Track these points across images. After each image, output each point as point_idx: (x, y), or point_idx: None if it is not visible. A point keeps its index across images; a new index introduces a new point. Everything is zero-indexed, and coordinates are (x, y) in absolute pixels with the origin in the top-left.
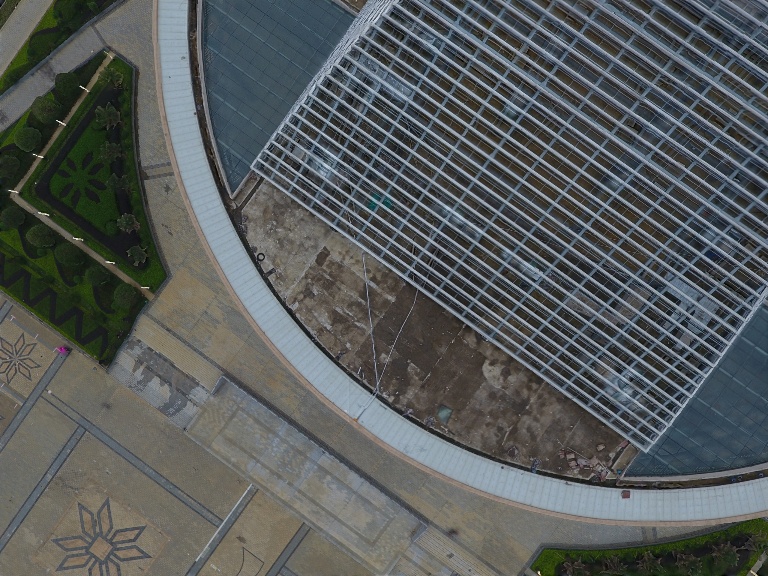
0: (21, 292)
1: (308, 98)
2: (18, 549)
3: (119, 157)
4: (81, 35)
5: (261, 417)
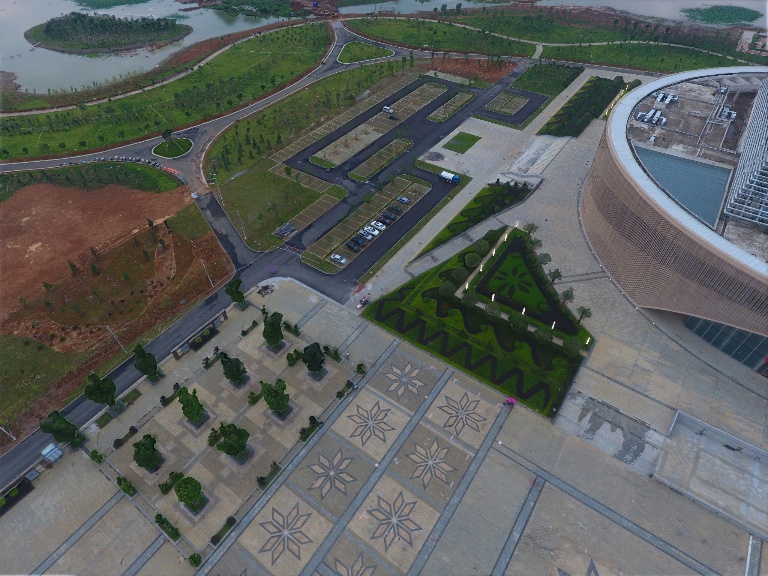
0: (463, 359)
1: (754, 177)
2: None
3: (534, 271)
4: (487, 221)
5: (726, 457)
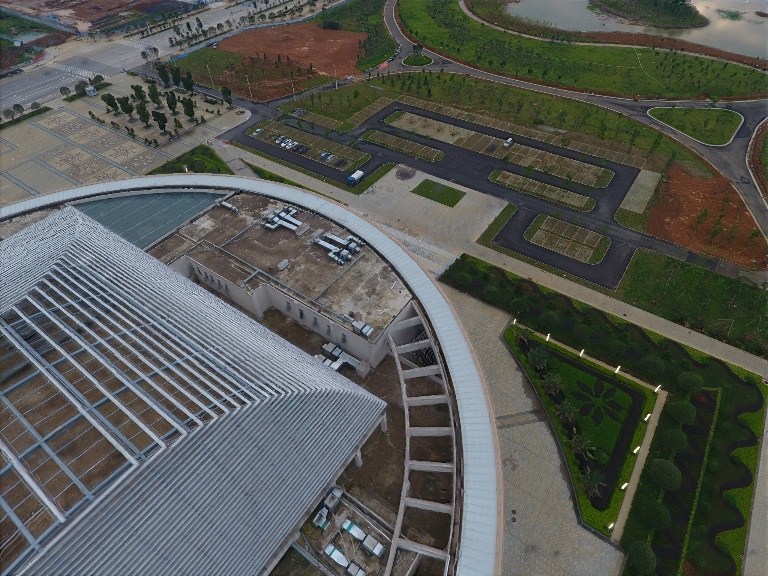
0: None
1: None
2: (2, 183)
3: None
4: None
5: None
